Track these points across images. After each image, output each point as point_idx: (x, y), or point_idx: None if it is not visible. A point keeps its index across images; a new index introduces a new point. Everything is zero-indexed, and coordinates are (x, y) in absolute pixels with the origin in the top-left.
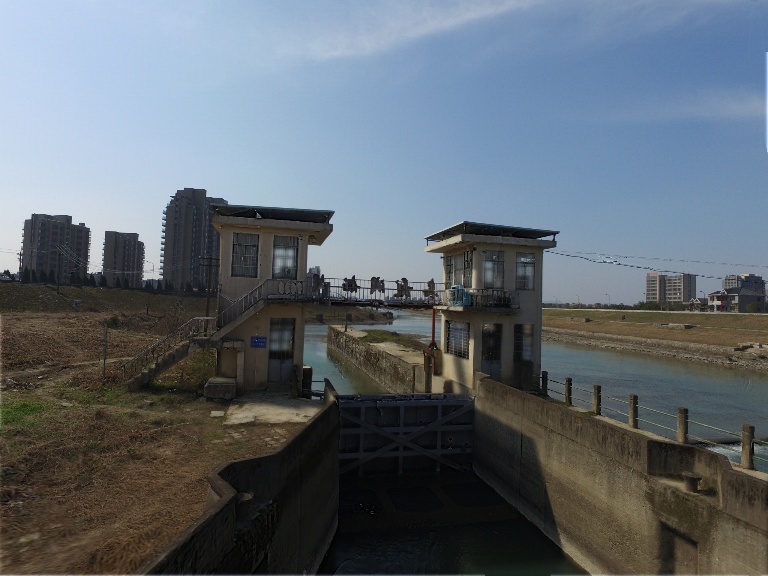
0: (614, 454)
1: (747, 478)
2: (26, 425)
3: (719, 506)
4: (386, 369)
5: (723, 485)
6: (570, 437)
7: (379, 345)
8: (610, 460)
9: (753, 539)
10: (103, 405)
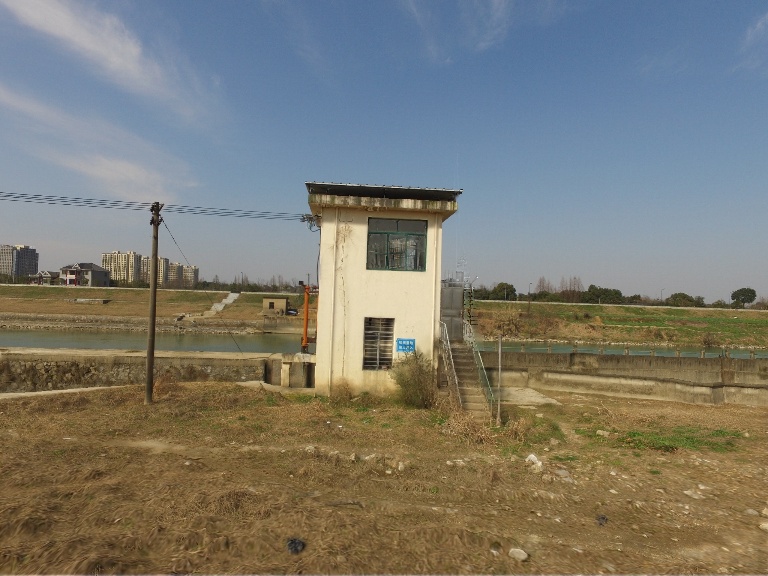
0: (553, 364)
1: (606, 355)
2: (690, 429)
3: (596, 367)
4: (141, 379)
5: (599, 360)
6: (525, 365)
7: (42, 352)
8: (552, 367)
9: (609, 372)
10: (563, 429)
